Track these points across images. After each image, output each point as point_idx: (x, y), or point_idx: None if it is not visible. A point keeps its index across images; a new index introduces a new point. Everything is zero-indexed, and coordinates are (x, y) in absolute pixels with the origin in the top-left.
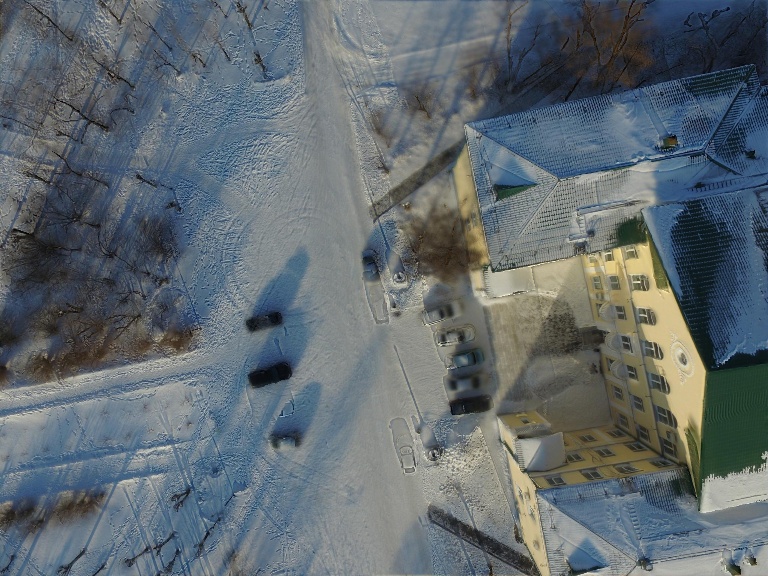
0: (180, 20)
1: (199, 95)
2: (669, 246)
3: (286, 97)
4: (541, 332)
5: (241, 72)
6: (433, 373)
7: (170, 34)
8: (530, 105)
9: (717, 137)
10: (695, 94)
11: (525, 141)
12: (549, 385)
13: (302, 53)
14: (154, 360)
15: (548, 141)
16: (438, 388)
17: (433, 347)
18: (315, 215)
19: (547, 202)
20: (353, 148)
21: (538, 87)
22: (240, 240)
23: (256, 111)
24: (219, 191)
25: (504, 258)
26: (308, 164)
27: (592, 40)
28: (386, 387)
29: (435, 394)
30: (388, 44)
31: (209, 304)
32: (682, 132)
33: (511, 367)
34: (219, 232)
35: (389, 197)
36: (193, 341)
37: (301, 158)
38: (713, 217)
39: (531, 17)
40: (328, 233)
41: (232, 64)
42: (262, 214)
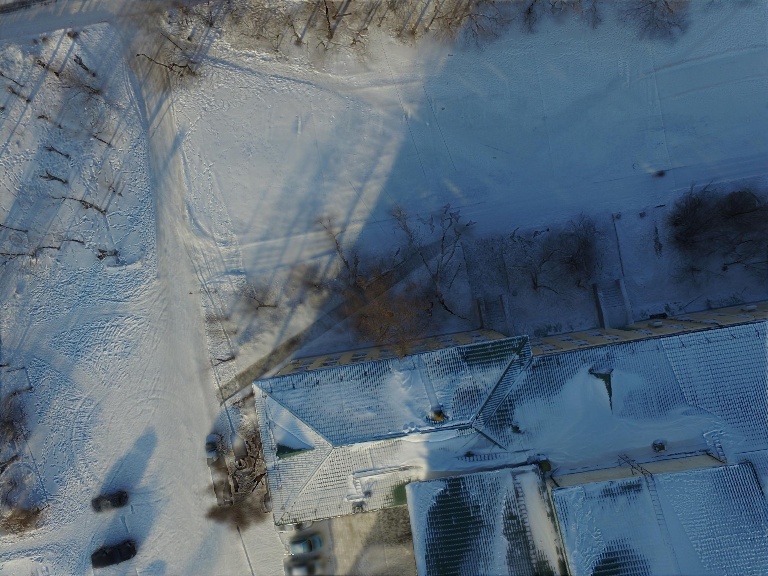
0: (36, 203)
1: (53, 277)
2: (423, 530)
3: (138, 281)
4: (375, 522)
5: (94, 256)
6: (274, 555)
7: (26, 217)
8: (373, 297)
9: (486, 409)
10: (469, 364)
11: (306, 404)
12: (382, 574)
13: (155, 239)
14: (2, 536)
15: (328, 405)
16: (278, 570)
17: (274, 529)
18: (164, 397)
19: (324, 466)
20: (202, 332)
21: (382, 279)
22: (90, 419)
23: (109, 294)
24: (71, 370)
25: (286, 514)
26: (158, 347)
27: (434, 236)
28: (228, 567)
29: (275, 575)
30: (238, 233)
31: (58, 481)
32: (453, 404)
33: (347, 554)
34: (70, 411)
35: (236, 382)
36: (41, 517)
37: (151, 341)
38: (469, 499)
39: (376, 212)
40: (176, 414)
41: (86, 248)
42: (112, 394)
